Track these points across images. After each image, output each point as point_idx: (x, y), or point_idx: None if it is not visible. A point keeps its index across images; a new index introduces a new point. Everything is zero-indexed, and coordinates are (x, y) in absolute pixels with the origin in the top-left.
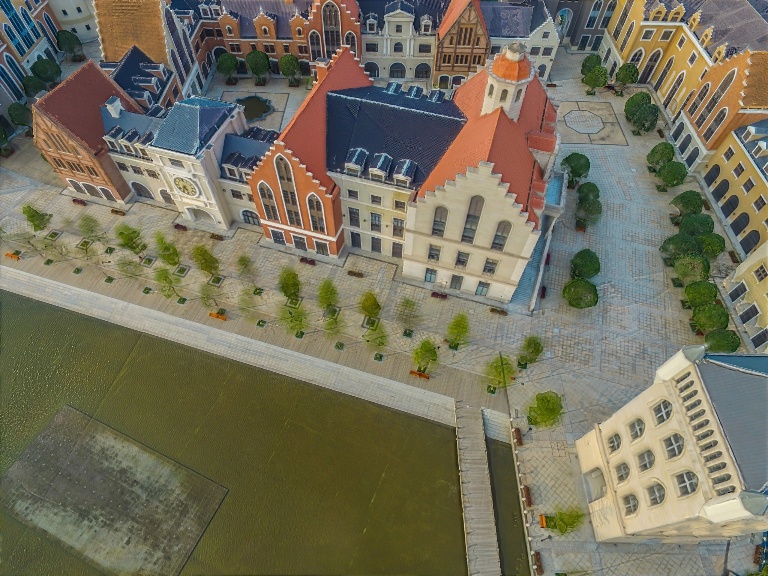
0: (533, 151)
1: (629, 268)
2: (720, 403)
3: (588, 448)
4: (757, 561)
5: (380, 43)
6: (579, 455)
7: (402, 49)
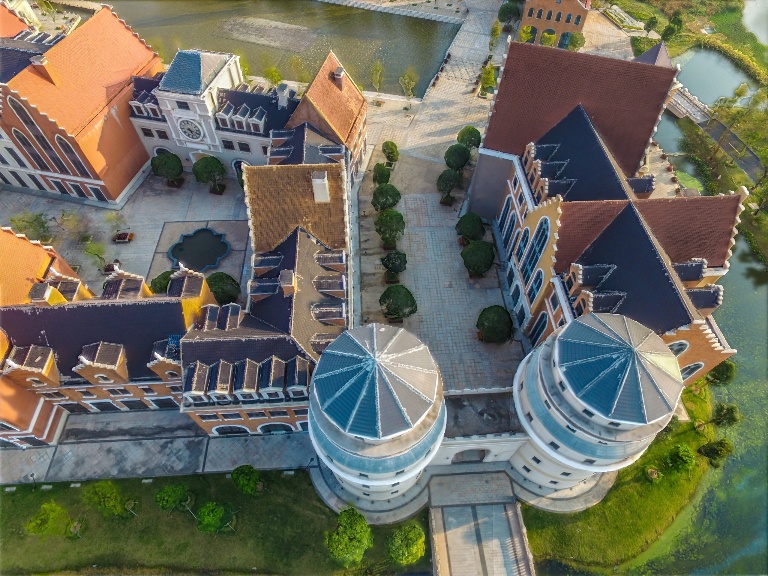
0: None
1: None
2: None
3: None
4: None
5: None
6: None
7: None
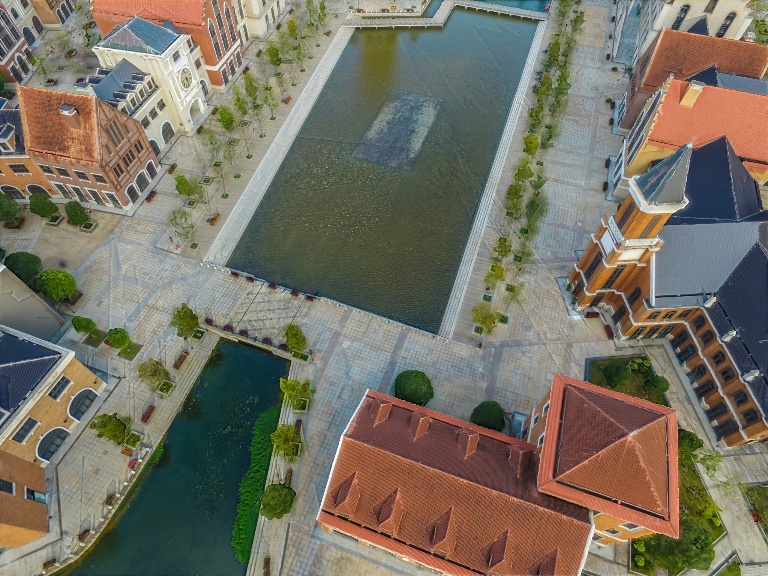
0: None
1: None
2: None
3: None
4: None
5: None
6: None
7: (16, 13)
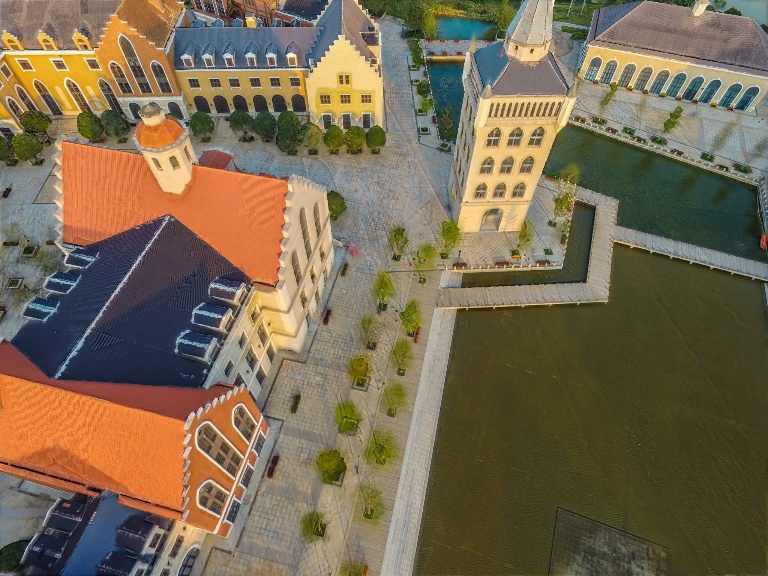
0: None
1: None
2: (519, 91)
3: (469, 219)
4: None
5: None
6: (466, 231)
7: None
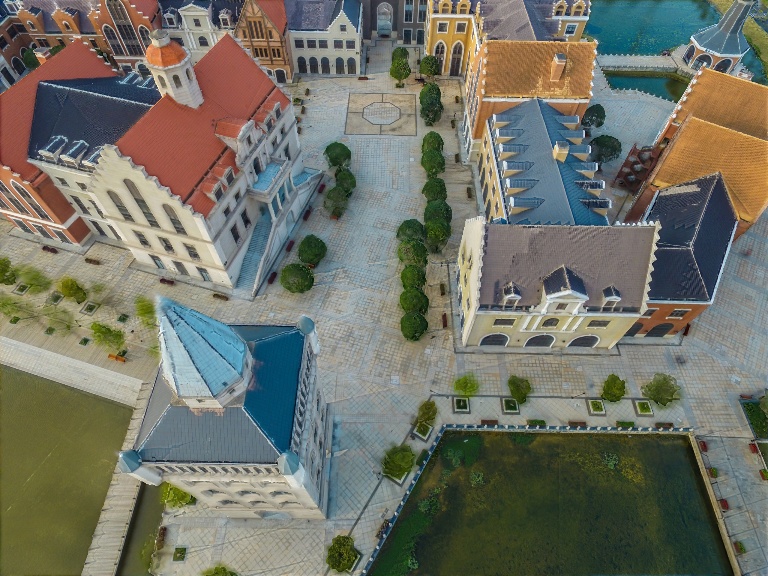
0: (220, 137)
1: (368, 254)
2: None
3: None
4: (377, 535)
5: (184, 37)
6: None
7: (207, 43)
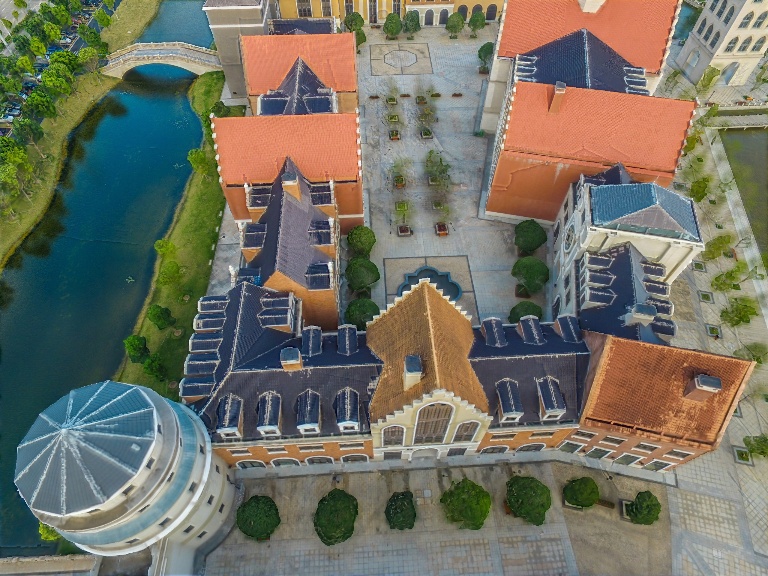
0: None
1: None
2: None
3: None
4: None
5: None
6: None
7: None
